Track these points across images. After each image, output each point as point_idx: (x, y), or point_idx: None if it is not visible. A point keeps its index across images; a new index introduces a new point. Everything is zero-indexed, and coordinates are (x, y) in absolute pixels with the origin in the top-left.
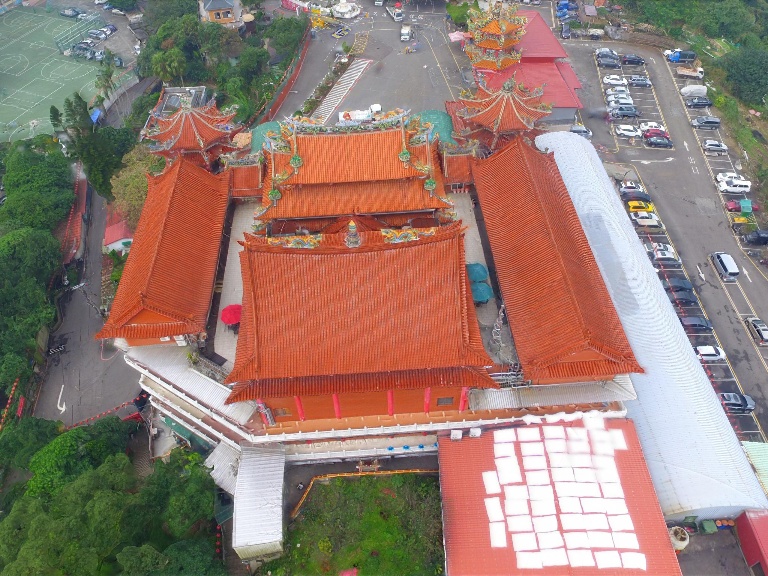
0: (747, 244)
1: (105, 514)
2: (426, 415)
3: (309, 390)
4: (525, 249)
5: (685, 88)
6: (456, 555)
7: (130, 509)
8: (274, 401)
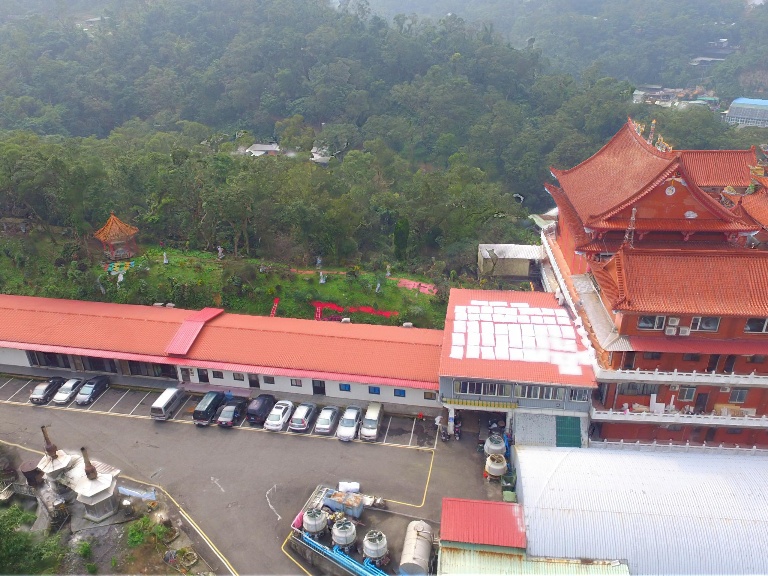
0: None
1: None
2: None
3: (560, 203)
4: None
5: None
6: (467, 291)
7: None
8: None
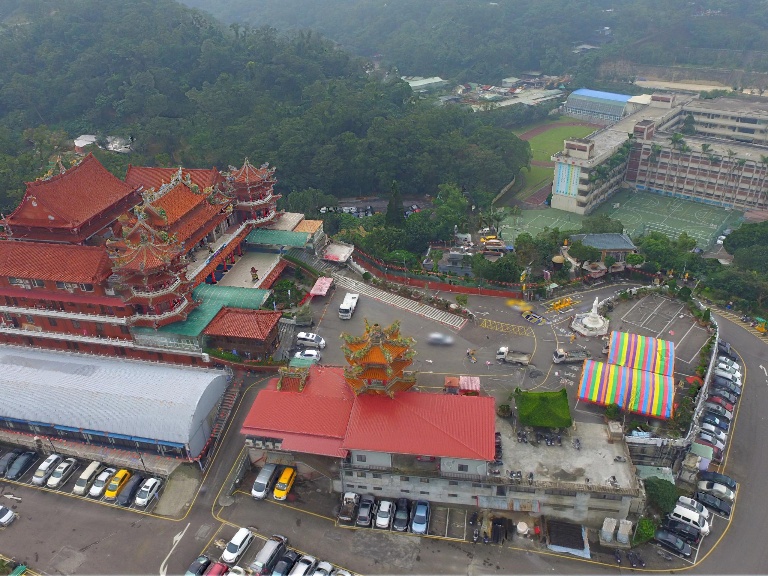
0: None
1: None
2: None
3: None
4: None
5: None
6: None
7: None
8: None
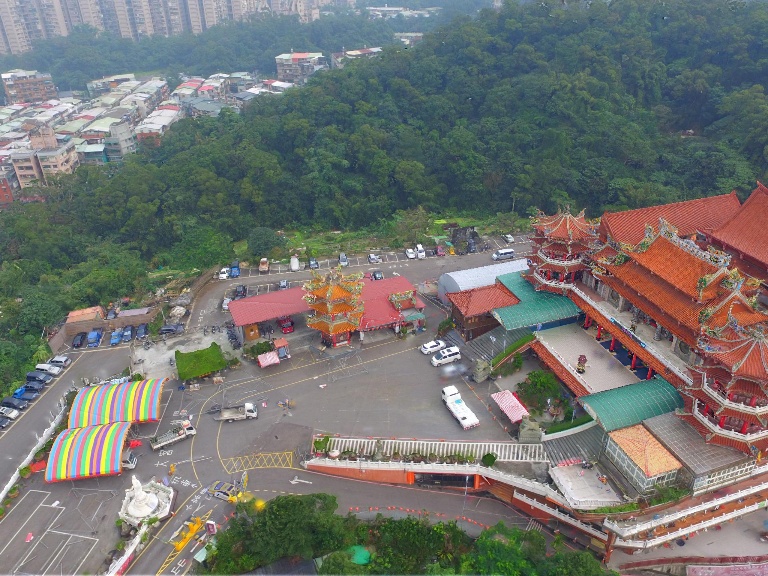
0: (476, 251)
1: None
2: None
3: None
4: (685, 219)
5: (294, 266)
6: None
7: None
8: None
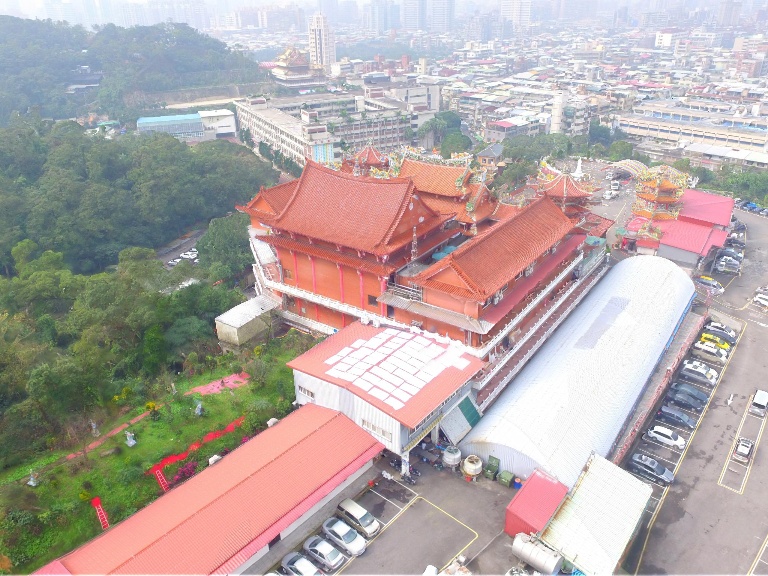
0: None
1: (177, 270)
2: (361, 309)
3: (296, 247)
4: None
5: None
6: (303, 358)
7: (193, 291)
8: (285, 260)
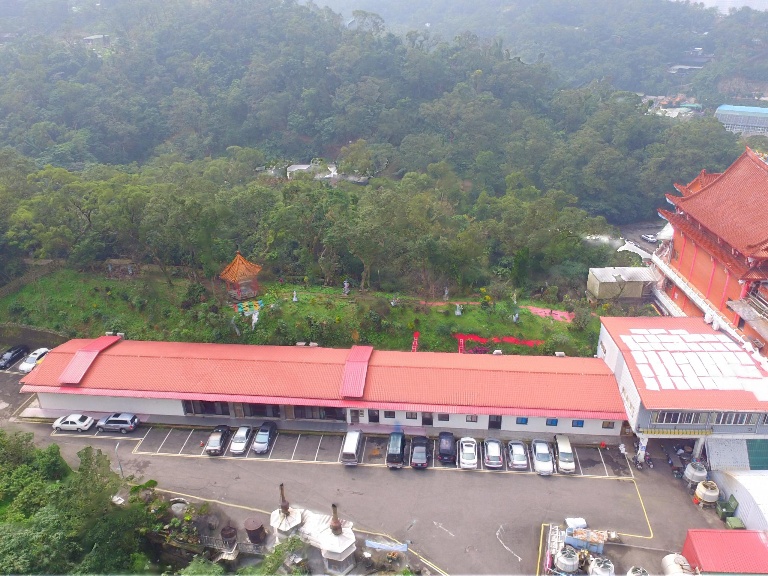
0: None
1: None
2: (717, 310)
3: (686, 229)
4: None
5: None
6: (618, 319)
7: (596, 244)
8: None
